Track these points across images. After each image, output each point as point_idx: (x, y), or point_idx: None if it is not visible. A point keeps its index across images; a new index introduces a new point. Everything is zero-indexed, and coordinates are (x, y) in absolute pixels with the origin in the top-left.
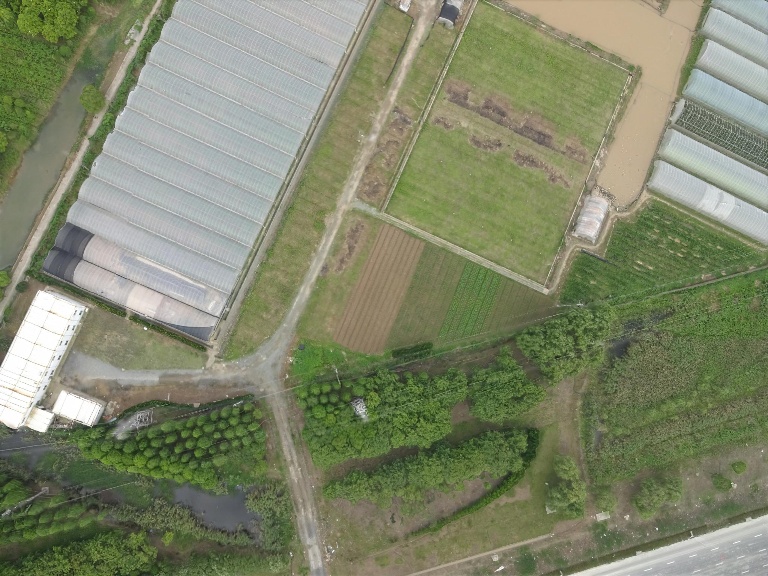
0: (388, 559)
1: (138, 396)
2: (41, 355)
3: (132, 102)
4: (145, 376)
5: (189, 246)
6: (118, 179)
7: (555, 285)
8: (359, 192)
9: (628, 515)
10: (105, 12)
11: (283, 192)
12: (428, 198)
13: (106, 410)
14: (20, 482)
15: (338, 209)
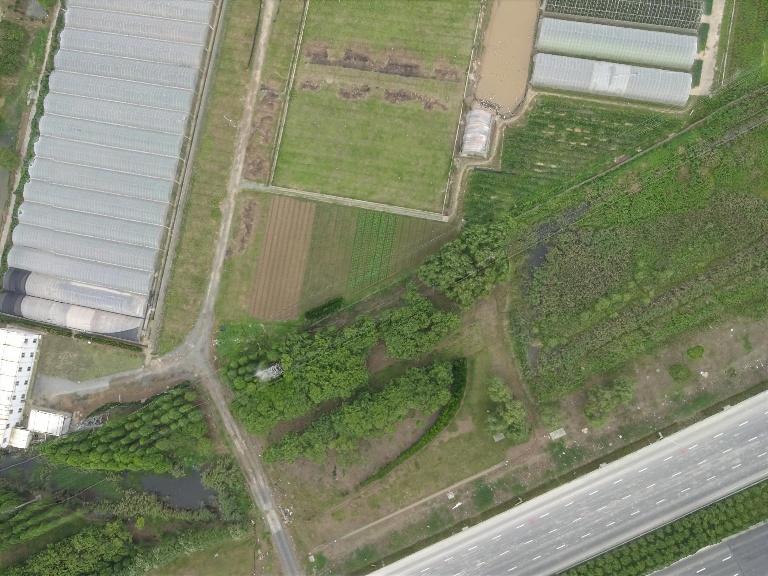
0: (344, 513)
1: (95, 403)
2: (6, 382)
3: (37, 151)
4: (97, 384)
5: (107, 261)
6: (39, 219)
7: (454, 210)
8: (245, 173)
9: (586, 428)
10: (8, 83)
11: (179, 193)
12: (310, 160)
13: (73, 420)
14: (14, 494)
15: (229, 194)
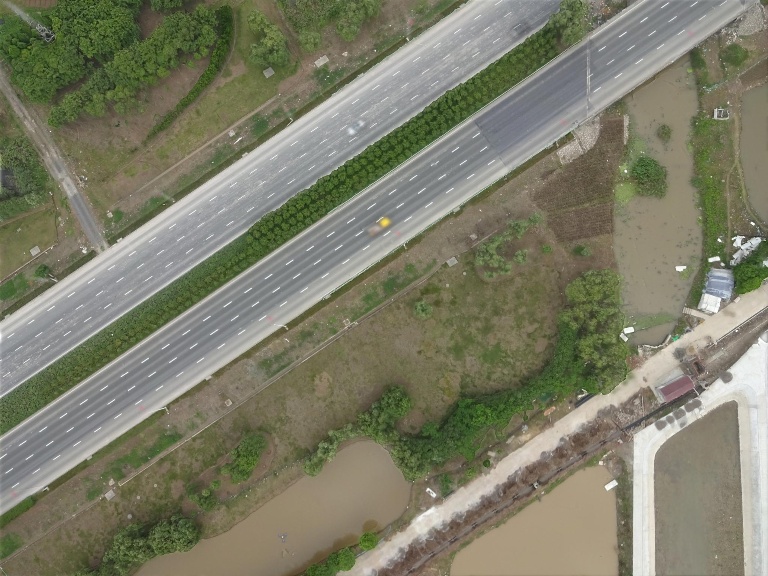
0: (136, 168)
1: None
2: None
3: None
4: None
5: None
6: None
7: None
8: None
9: (346, 52)
10: None
11: None
12: None
13: None
14: None
15: None
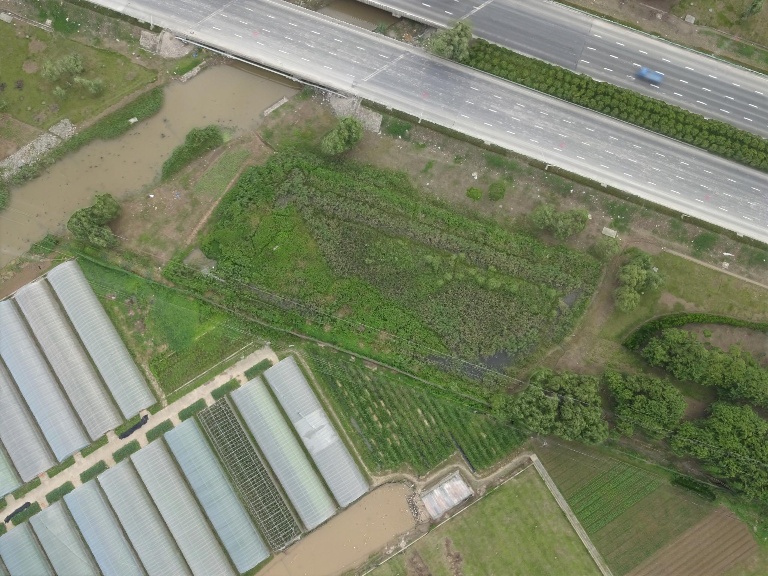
0: None
1: None
2: None
3: None
4: None
5: None
6: None
7: (521, 457)
8: None
9: None
10: None
11: None
12: None
13: None
14: None
15: None
